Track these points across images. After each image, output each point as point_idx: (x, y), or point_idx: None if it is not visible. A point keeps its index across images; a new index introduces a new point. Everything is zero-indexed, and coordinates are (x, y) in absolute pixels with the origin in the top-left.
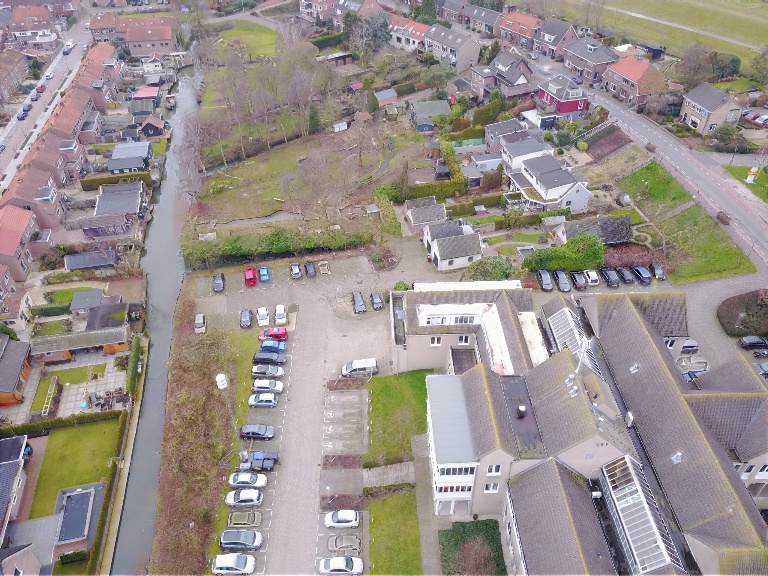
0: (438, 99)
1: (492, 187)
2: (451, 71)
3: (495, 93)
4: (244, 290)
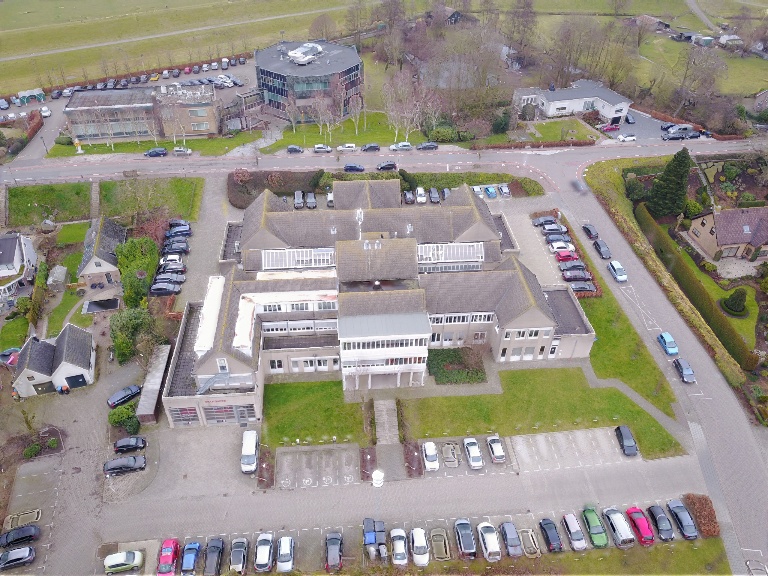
0: None
1: None
2: None
3: None
4: None
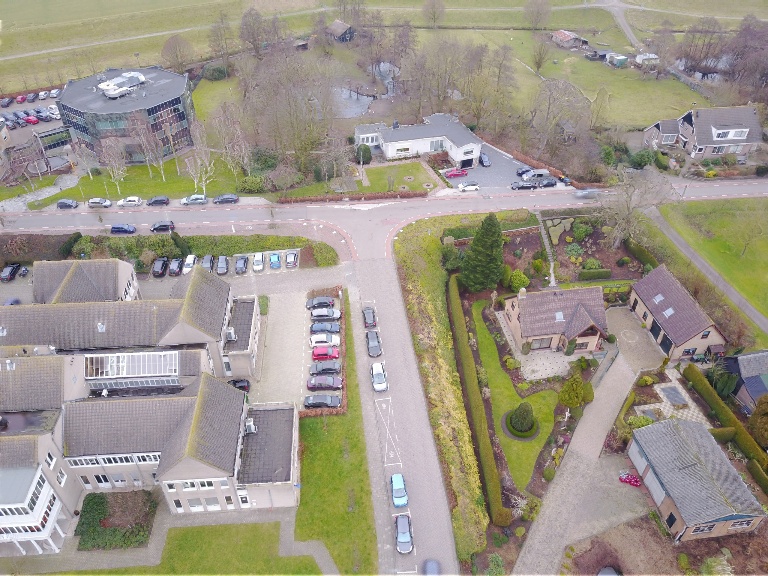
0: None
1: None
2: None
3: None
4: None
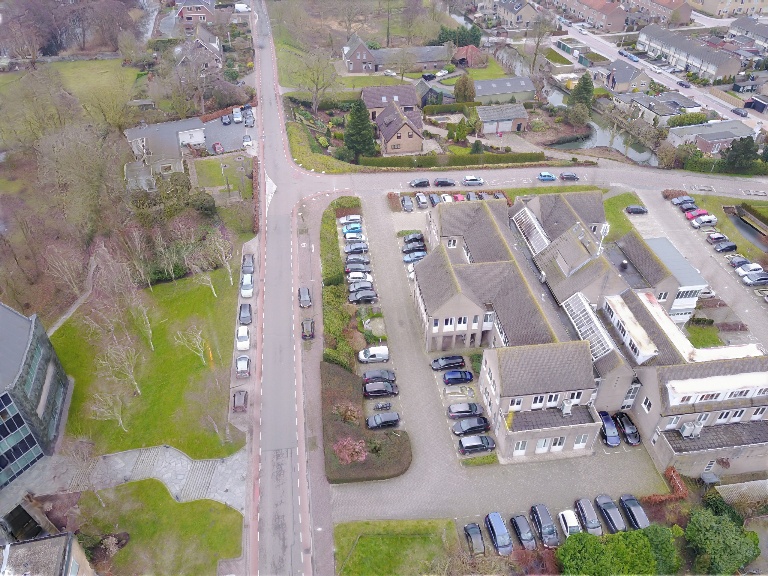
0: None
1: None
2: None
3: None
4: None
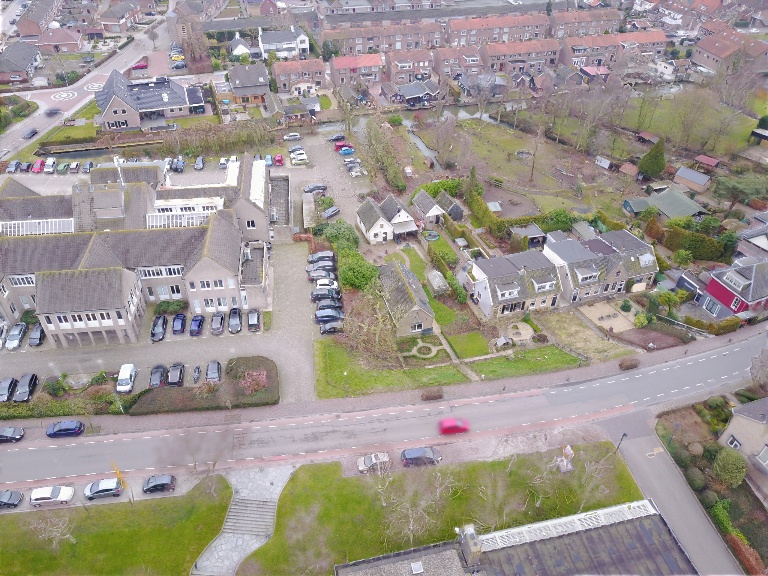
0: (724, 215)
1: (513, 253)
2: (747, 190)
3: (727, 234)
4: (331, 148)
